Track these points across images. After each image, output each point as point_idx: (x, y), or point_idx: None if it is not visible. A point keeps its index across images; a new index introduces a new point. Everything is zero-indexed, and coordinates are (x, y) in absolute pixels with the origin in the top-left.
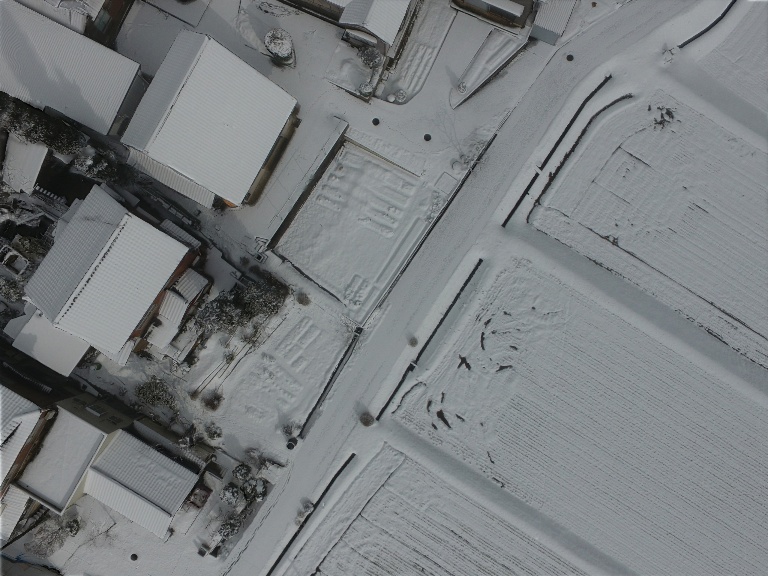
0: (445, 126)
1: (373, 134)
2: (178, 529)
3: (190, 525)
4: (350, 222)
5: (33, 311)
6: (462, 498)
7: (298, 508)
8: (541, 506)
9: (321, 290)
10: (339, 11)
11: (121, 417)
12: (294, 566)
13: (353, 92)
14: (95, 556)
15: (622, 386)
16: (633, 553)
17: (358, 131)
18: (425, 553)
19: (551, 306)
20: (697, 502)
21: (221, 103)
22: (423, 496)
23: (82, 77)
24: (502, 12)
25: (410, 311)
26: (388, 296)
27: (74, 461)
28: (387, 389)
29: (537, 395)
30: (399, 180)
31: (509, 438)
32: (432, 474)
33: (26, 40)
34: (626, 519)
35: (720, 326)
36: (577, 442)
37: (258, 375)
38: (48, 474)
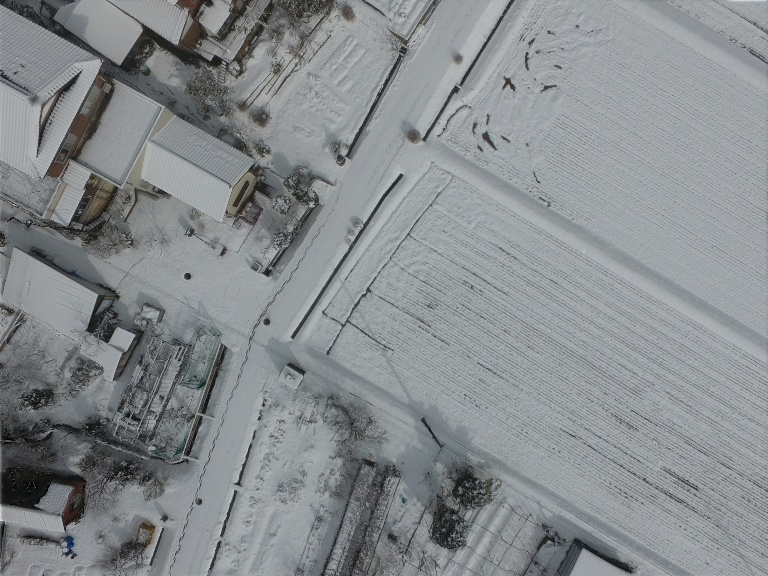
0: None
1: None
2: (230, 247)
3: (242, 243)
4: None
5: None
6: (509, 215)
7: (348, 227)
8: (587, 223)
9: (366, 4)
10: None
11: None
12: (345, 287)
13: None
14: (149, 275)
15: (667, 101)
16: (678, 267)
17: None
18: (474, 270)
19: (595, 23)
20: (741, 214)
21: None
22: (471, 214)
23: None
24: None
25: (454, 29)
26: (432, 15)
27: (132, 137)
28: (433, 108)
29: (582, 113)
30: None
31: (555, 157)
32: (479, 192)
33: None
34: (671, 234)
35: (763, 47)
36: (622, 158)
37: (304, 95)
38: (106, 151)
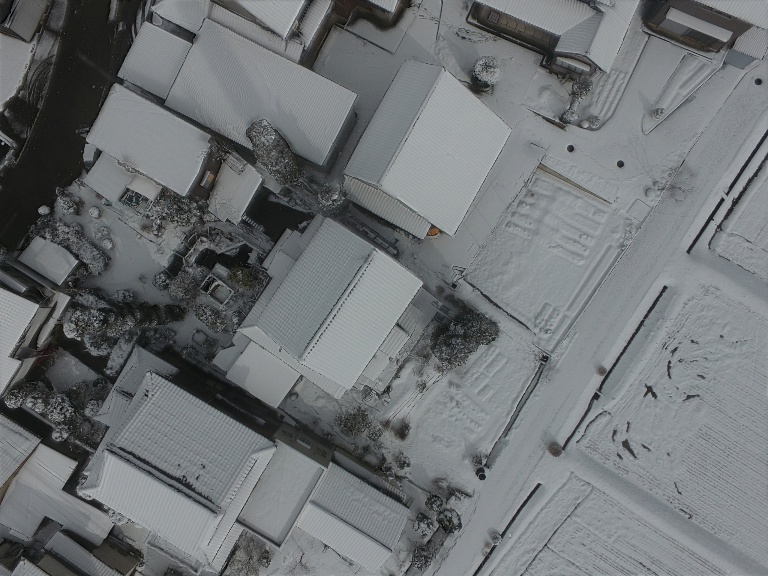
0: (637, 152)
1: (568, 161)
2: None
3: None
4: (541, 250)
5: (245, 342)
6: (651, 530)
7: (485, 539)
8: (730, 538)
9: (510, 318)
10: (547, 38)
11: (323, 448)
12: None
13: (551, 119)
14: None
15: None
16: None
17: (553, 158)
18: None
19: (740, 334)
20: None
21: (448, 134)
22: (611, 527)
23: (298, 107)
24: (702, 37)
25: (597, 339)
26: None
27: (291, 495)
28: (574, 418)
29: (726, 425)
30: (590, 207)
31: (697, 469)
32: (620, 505)
33: (256, 72)
34: None
35: None
36: (767, 473)
37: (444, 404)
38: (265, 508)
